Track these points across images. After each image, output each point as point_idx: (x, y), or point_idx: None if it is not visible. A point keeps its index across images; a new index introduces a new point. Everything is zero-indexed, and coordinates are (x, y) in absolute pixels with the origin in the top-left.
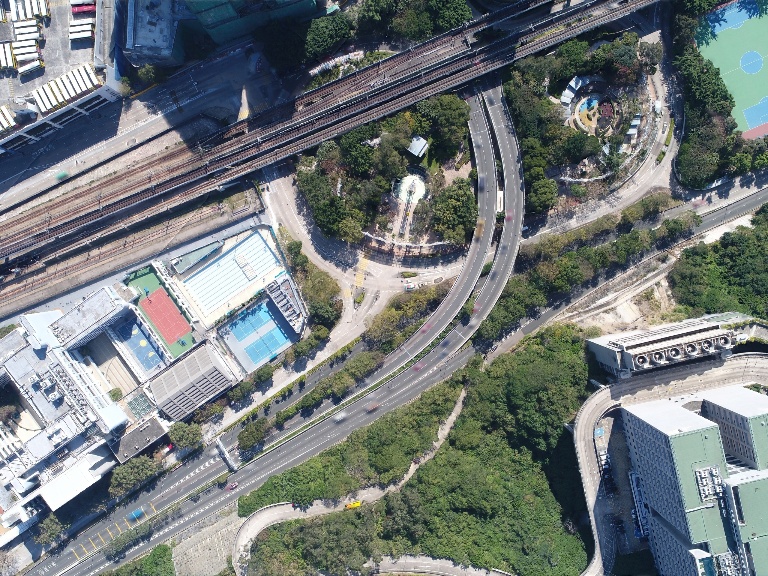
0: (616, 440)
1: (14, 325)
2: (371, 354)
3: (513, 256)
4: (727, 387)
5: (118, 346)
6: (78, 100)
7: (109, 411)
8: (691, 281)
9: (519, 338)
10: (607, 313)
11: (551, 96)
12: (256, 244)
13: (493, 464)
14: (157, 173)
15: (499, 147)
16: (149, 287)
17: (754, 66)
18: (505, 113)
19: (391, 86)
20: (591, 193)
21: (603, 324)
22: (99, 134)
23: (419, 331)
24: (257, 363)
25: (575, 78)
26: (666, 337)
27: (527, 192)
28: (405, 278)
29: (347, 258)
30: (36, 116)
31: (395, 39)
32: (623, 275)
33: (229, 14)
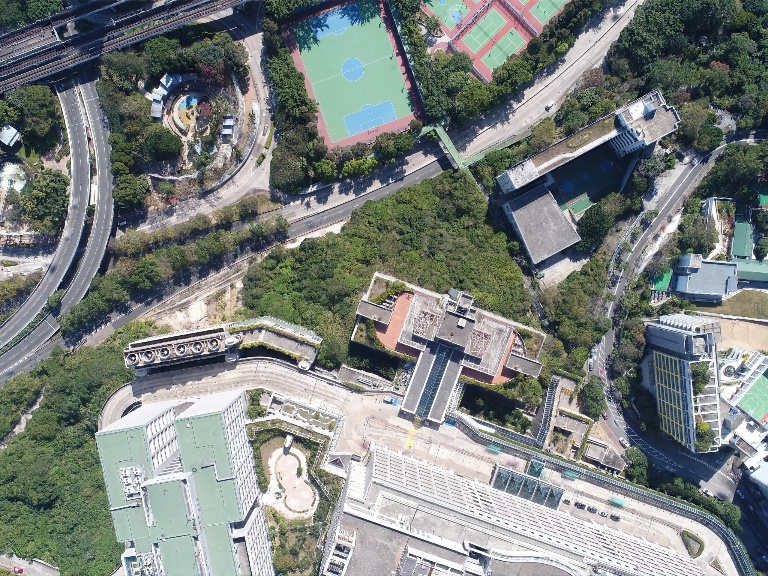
0: None
1: None
2: None
3: (103, 250)
4: (236, 390)
5: None
6: None
7: None
8: (256, 284)
9: (109, 332)
10: (180, 312)
11: (148, 92)
12: None
13: (68, 456)
14: None
15: (93, 140)
16: None
17: (355, 73)
18: None
19: None
20: (177, 191)
21: (174, 322)
22: None
23: (11, 320)
24: None
25: (166, 75)
26: (172, 337)
27: None
28: (5, 266)
29: None
30: None
31: None
32: (216, 275)
33: None
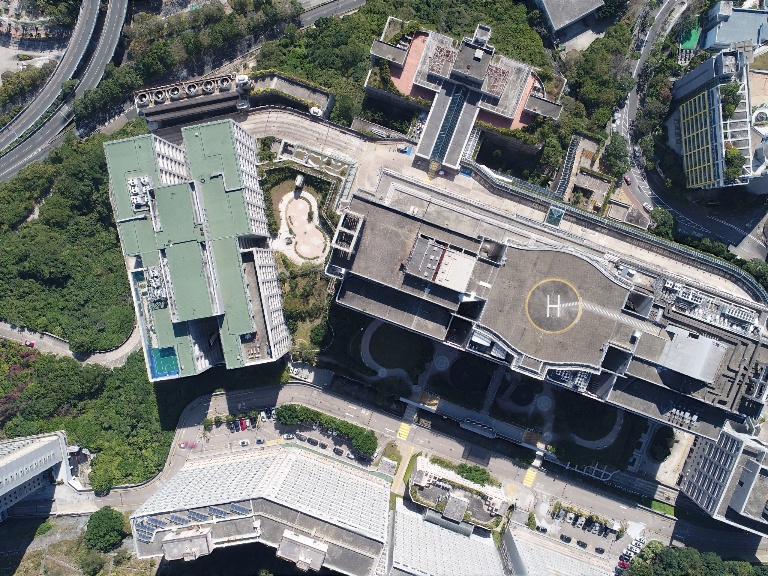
0: None
1: None
2: None
3: (117, 38)
4: None
5: None
6: None
7: None
8: (269, 59)
9: (123, 123)
10: None
11: None
12: None
13: (80, 243)
14: None
15: None
16: None
17: None
18: None
19: None
20: None
21: None
22: None
23: (26, 111)
24: None
25: None
26: None
27: None
28: (21, 61)
29: None
30: None
31: None
32: (230, 65)
33: None
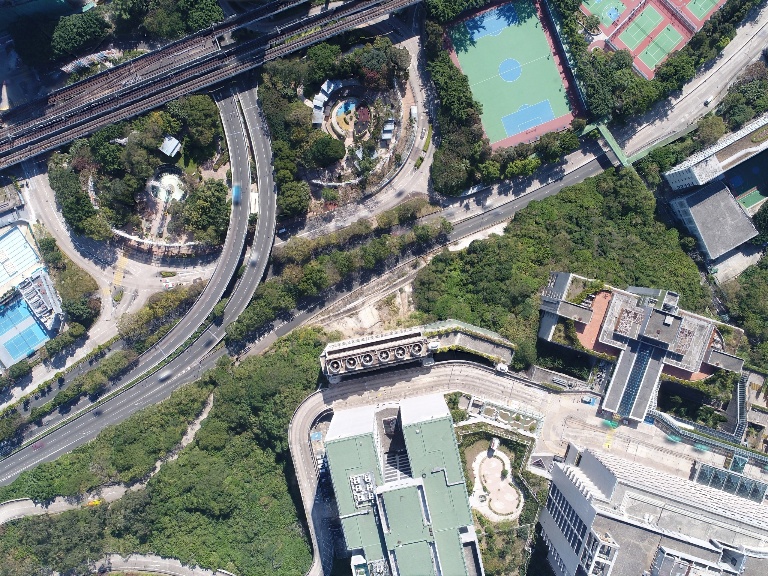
0: None
1: None
2: (123, 352)
3: (266, 258)
4: (432, 394)
5: None
6: None
7: None
8: (429, 287)
9: (272, 340)
10: (350, 317)
11: (307, 99)
12: (16, 240)
13: (238, 465)
14: None
15: (253, 149)
16: None
17: (512, 74)
18: (260, 115)
19: (142, 85)
20: (341, 197)
21: (345, 328)
22: None
23: (173, 331)
24: (16, 359)
25: (327, 82)
26: (368, 343)
27: (278, 194)
28: (164, 277)
29: (106, 256)
30: None
31: (153, 38)
32: (378, 280)
33: None
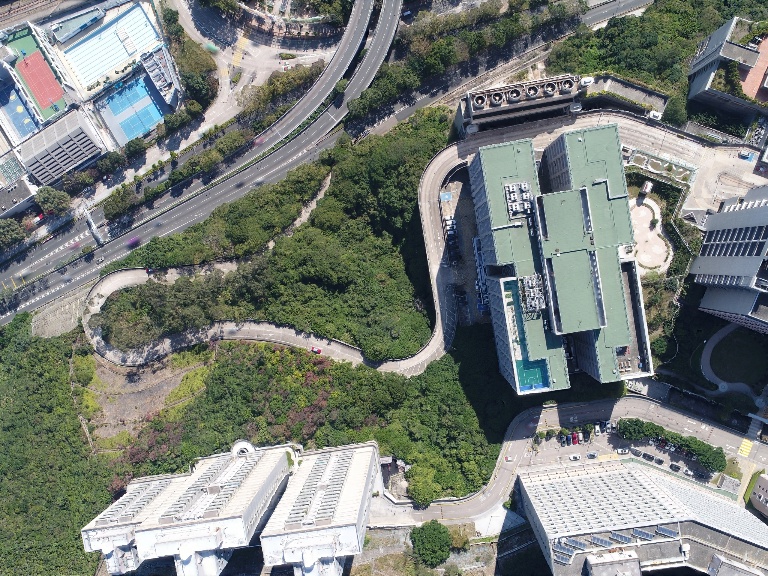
0: (464, 206)
1: None
2: (240, 131)
3: (390, 37)
4: None
5: None
6: None
7: None
8: (565, 60)
9: (392, 124)
10: None
11: None
12: (138, 18)
13: (353, 247)
14: None
15: None
16: (26, 49)
17: None
18: None
19: None
20: None
21: None
22: None
23: (291, 112)
24: (131, 139)
25: None
26: (513, 85)
27: None
28: (283, 60)
29: (226, 36)
30: None
31: None
32: (505, 65)
33: None
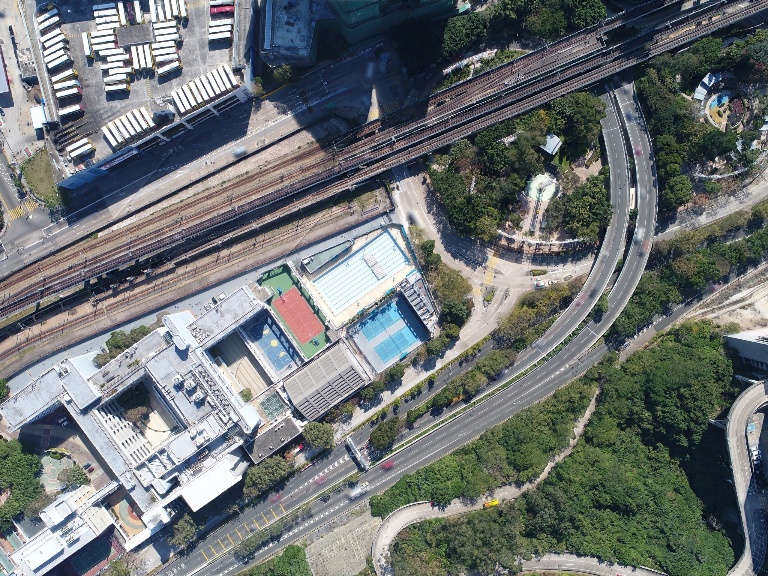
0: (767, 436)
1: (144, 326)
2: (504, 352)
3: (646, 253)
4: None
5: (250, 346)
6: (216, 100)
7: (246, 411)
8: None
9: (651, 335)
10: (745, 309)
11: (682, 93)
12: (385, 243)
13: (629, 461)
14: (289, 173)
15: (631, 144)
16: (282, 287)
17: None
18: (637, 110)
19: (526, 84)
20: (725, 189)
21: (741, 320)
22: (229, 135)
23: (551, 329)
24: (386, 362)
25: (708, 75)
26: None
27: (661, 189)
28: (535, 276)
29: (477, 256)
30: (173, 117)
31: (526, 37)
32: (754, 271)
33: (373, 13)
